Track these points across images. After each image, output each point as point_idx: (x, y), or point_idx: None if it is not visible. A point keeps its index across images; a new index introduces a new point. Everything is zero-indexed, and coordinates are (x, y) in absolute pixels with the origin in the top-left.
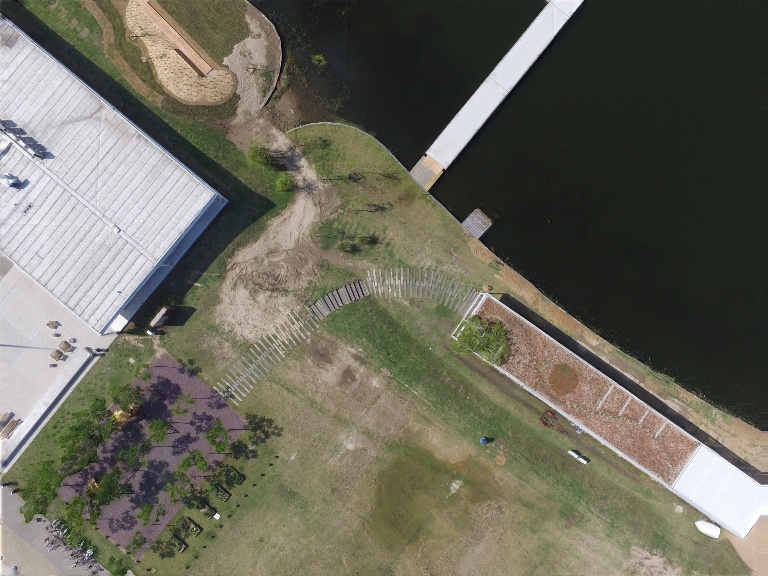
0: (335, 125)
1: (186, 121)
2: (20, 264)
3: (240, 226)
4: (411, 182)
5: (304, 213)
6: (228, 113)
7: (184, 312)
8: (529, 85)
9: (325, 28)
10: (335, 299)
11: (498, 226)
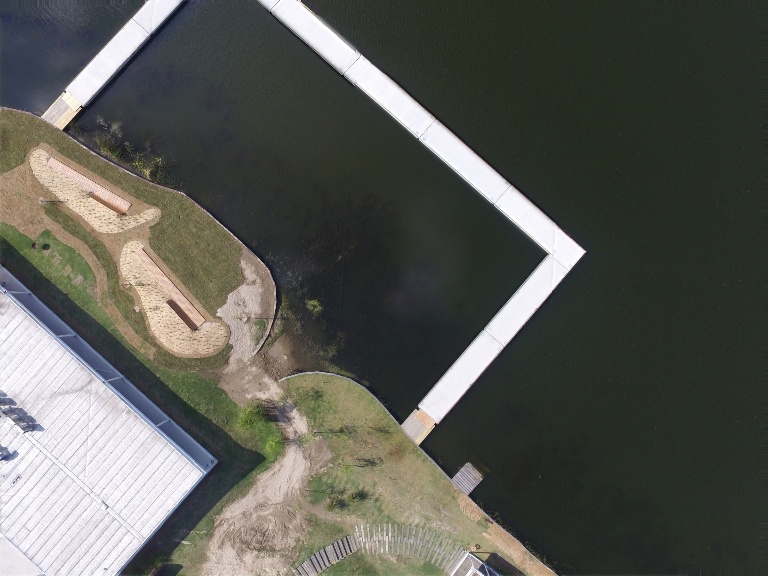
0: (328, 375)
1: (178, 373)
2: (8, 536)
3: (229, 484)
4: (402, 436)
5: (294, 466)
6: (220, 362)
7: (171, 569)
8: (525, 337)
9: (321, 272)
10: (322, 558)
11: (488, 480)
